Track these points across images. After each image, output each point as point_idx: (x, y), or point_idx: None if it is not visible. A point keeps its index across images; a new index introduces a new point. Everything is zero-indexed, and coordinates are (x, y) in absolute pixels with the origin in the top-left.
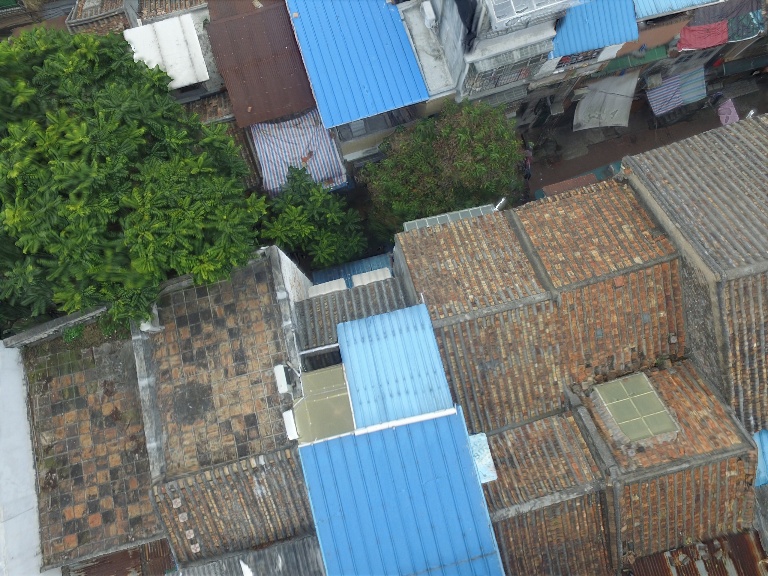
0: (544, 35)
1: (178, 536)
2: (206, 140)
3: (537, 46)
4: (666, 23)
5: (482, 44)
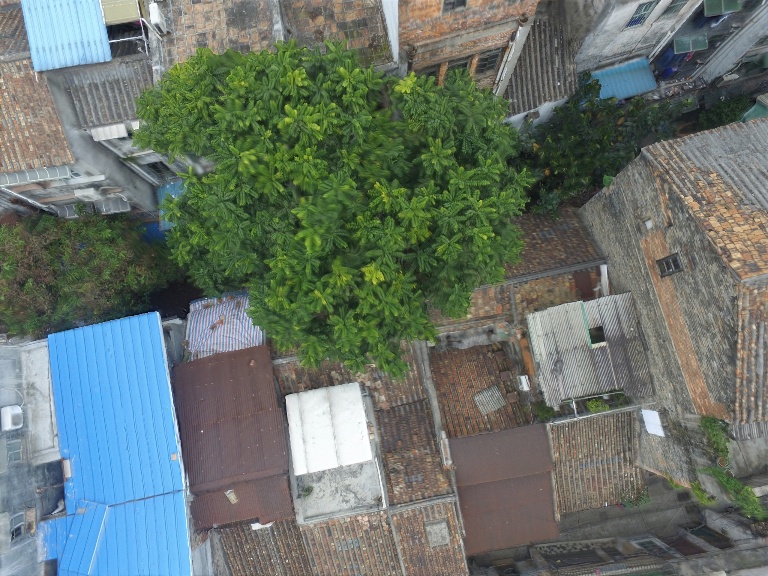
0: None
1: None
2: (176, 200)
3: None
4: None
5: None
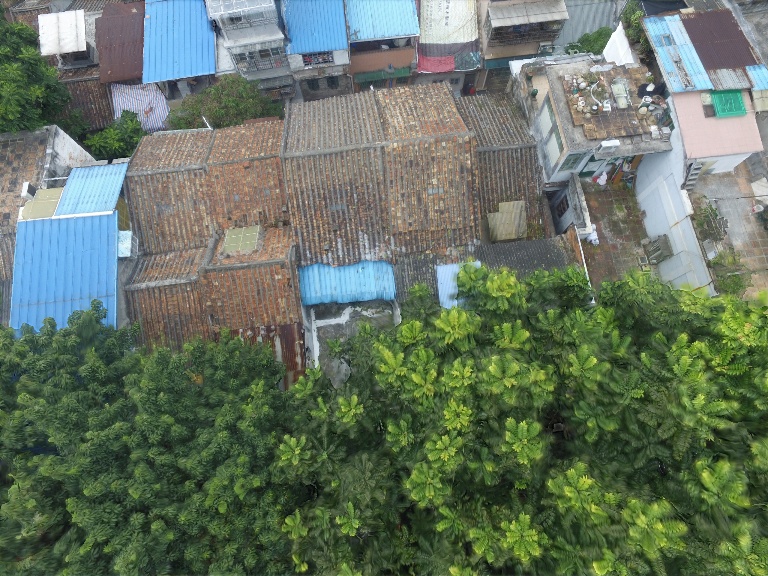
0: (276, 36)
1: None
2: (21, 56)
3: (272, 43)
4: (396, 49)
5: (233, 36)
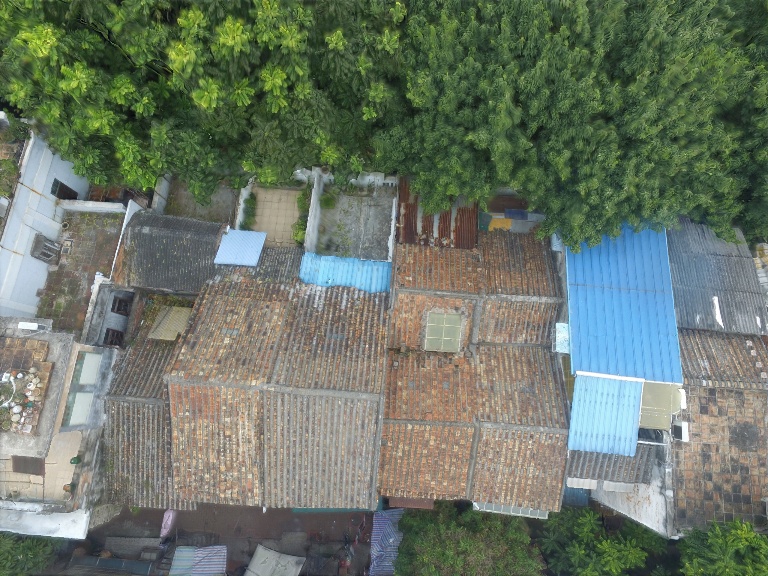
0: None
1: (761, 354)
2: None
3: None
4: None
5: None
